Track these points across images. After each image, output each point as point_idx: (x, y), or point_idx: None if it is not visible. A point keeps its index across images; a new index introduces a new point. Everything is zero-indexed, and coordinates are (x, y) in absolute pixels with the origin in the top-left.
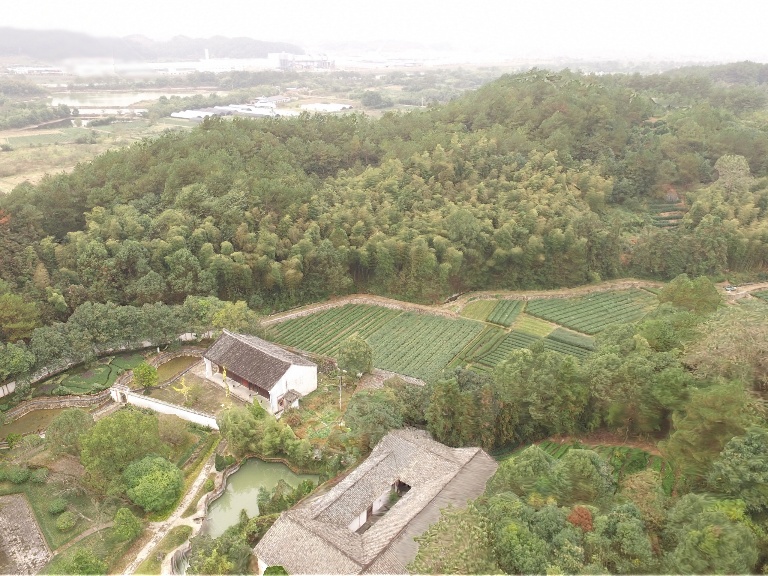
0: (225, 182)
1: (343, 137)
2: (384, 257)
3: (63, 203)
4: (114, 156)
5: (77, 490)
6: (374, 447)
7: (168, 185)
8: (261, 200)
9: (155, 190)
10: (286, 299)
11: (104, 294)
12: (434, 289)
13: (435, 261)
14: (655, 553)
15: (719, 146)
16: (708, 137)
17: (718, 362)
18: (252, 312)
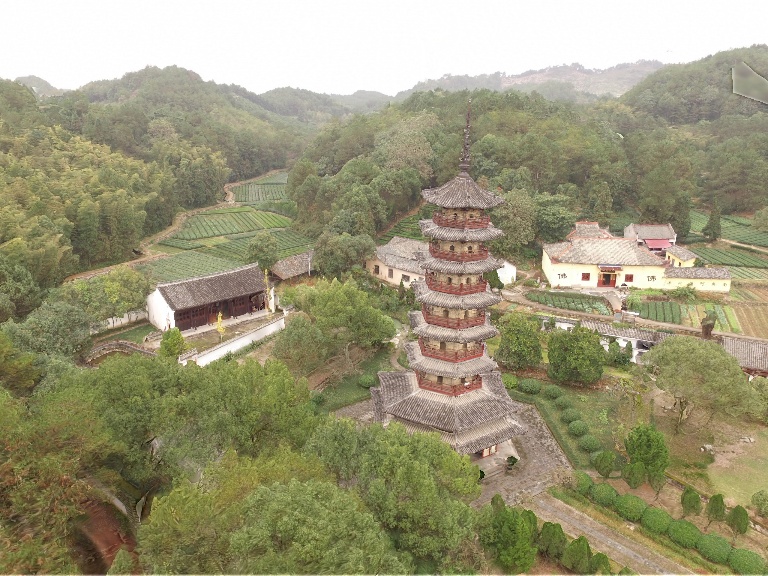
0: None
1: None
2: (93, 222)
3: None
4: None
5: None
6: (378, 258)
7: None
8: None
9: None
10: None
11: None
12: None
13: None
14: None
15: (127, 118)
16: None
17: (413, 159)
18: None
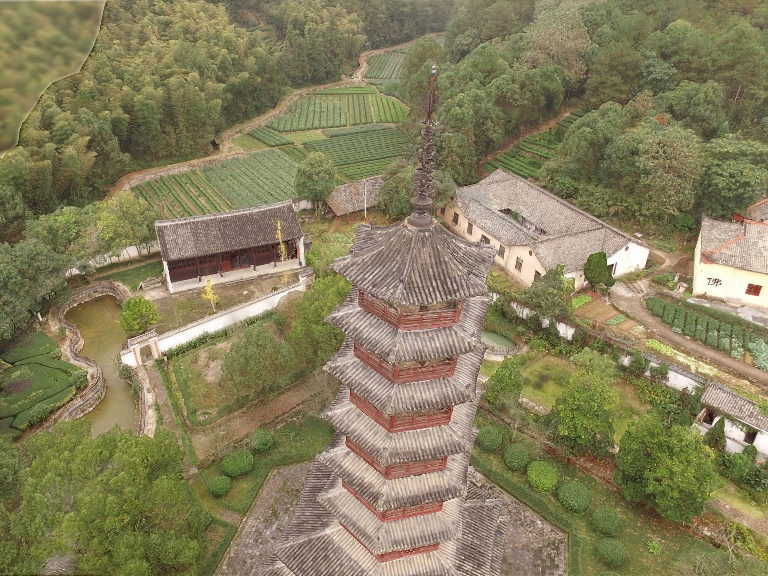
0: None
1: None
2: (152, 113)
3: None
4: None
5: None
6: (457, 205)
7: None
8: None
9: None
10: (77, 204)
11: None
12: (212, 134)
13: (205, 101)
14: None
15: None
16: None
17: None
18: None
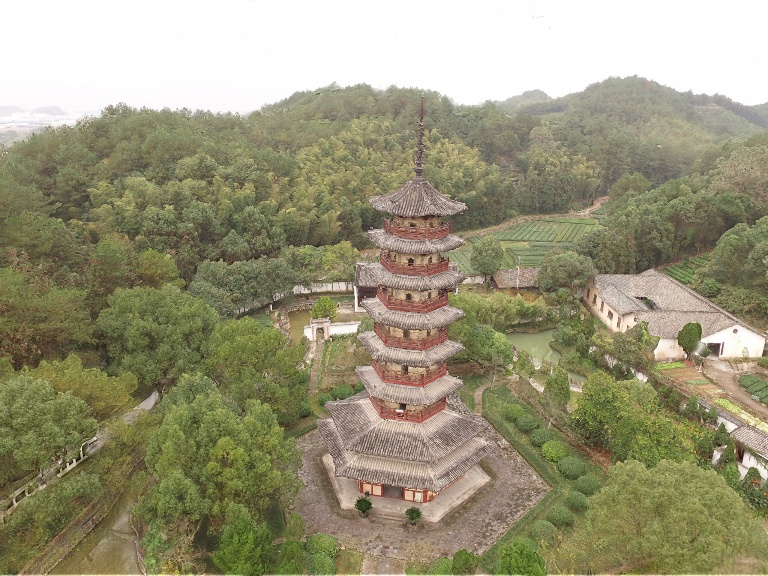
0: (221, 153)
1: None
2: None
3: None
4: (54, 138)
5: None
6: (595, 286)
7: (158, 160)
8: (269, 166)
9: (133, 169)
10: None
11: (196, 259)
12: None
13: None
14: None
15: (519, 125)
16: (504, 122)
17: (744, 182)
18: None
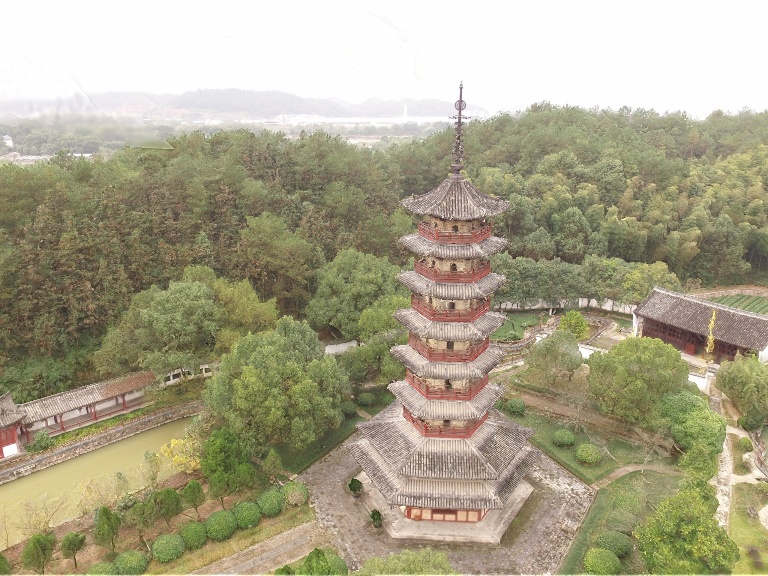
0: (592, 152)
1: (673, 132)
2: None
3: (413, 171)
4: None
5: (577, 424)
6: None
7: (527, 154)
8: (639, 170)
9: (507, 161)
10: None
11: None
12: None
13: None
14: None
15: None
16: None
17: None
18: (675, 275)
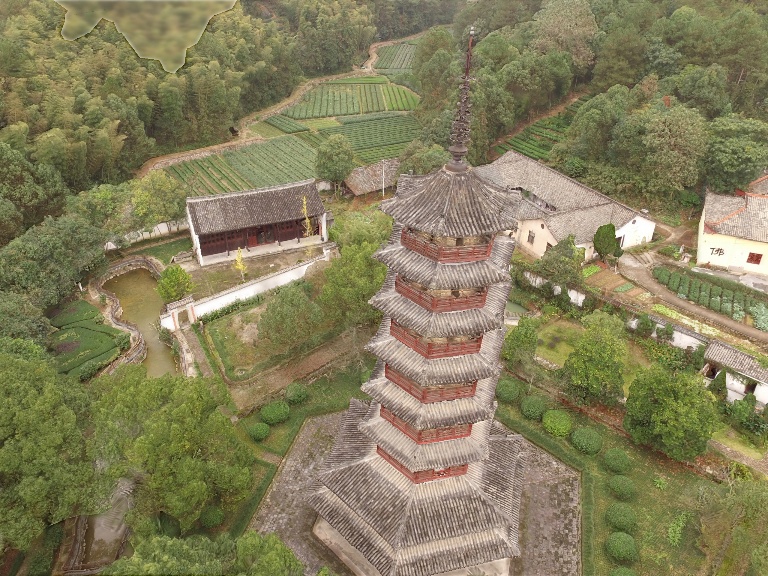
0: None
1: None
2: (175, 100)
3: None
4: None
5: None
6: None
7: None
8: None
9: None
10: None
11: None
12: (231, 121)
13: (225, 88)
14: (684, 106)
15: None
16: None
17: (567, 39)
18: None
